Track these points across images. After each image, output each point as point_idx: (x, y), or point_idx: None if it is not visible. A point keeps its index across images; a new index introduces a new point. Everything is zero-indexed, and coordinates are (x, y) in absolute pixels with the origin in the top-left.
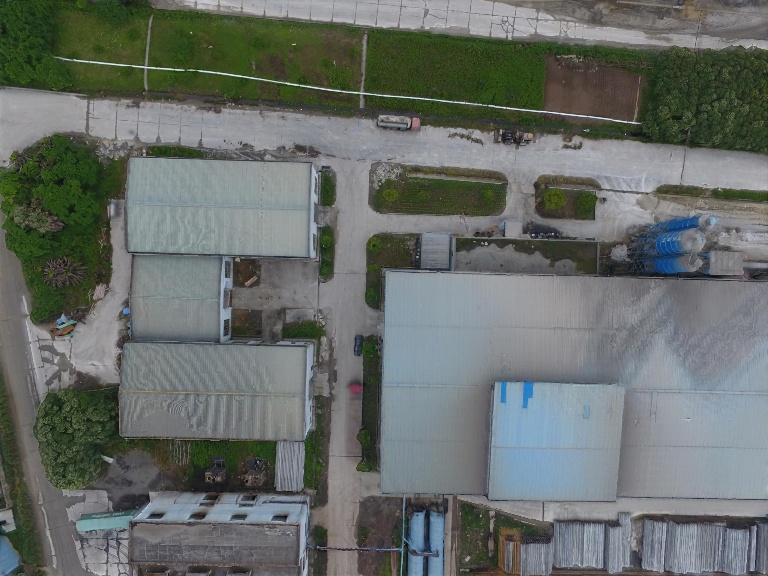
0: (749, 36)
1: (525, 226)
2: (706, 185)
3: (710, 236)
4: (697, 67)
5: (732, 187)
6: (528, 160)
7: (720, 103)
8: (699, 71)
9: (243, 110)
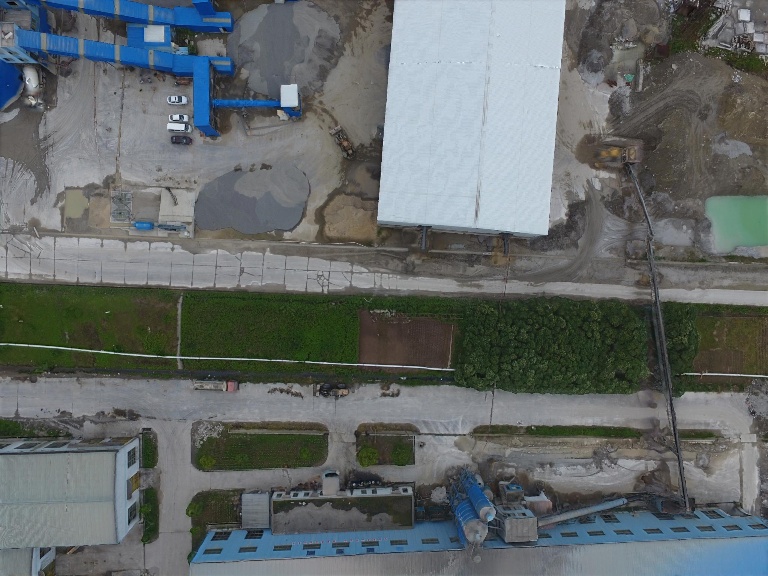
0: (556, 279)
1: (347, 474)
2: (520, 423)
3: (526, 472)
4: (498, 326)
5: (545, 424)
6: (348, 410)
7: (519, 362)
8: (500, 330)
9: (59, 378)
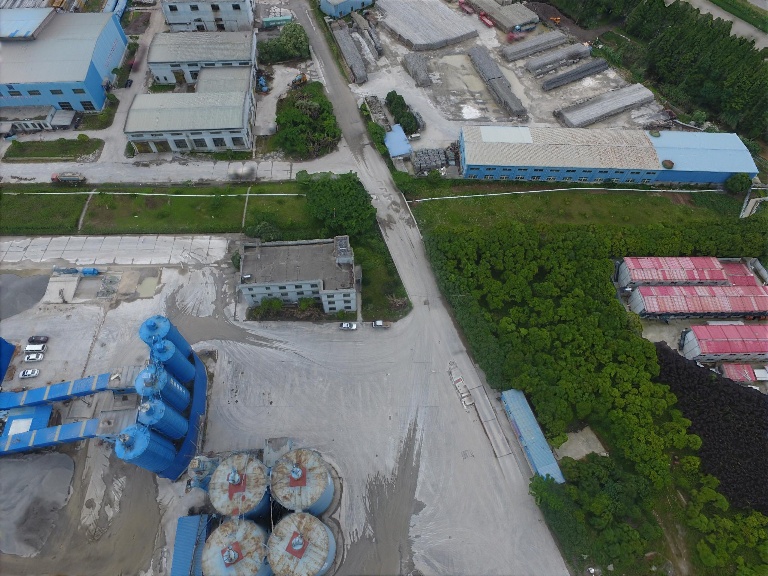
0: None
1: None
2: None
3: None
4: None
5: None
6: None
7: None
8: None
9: None
